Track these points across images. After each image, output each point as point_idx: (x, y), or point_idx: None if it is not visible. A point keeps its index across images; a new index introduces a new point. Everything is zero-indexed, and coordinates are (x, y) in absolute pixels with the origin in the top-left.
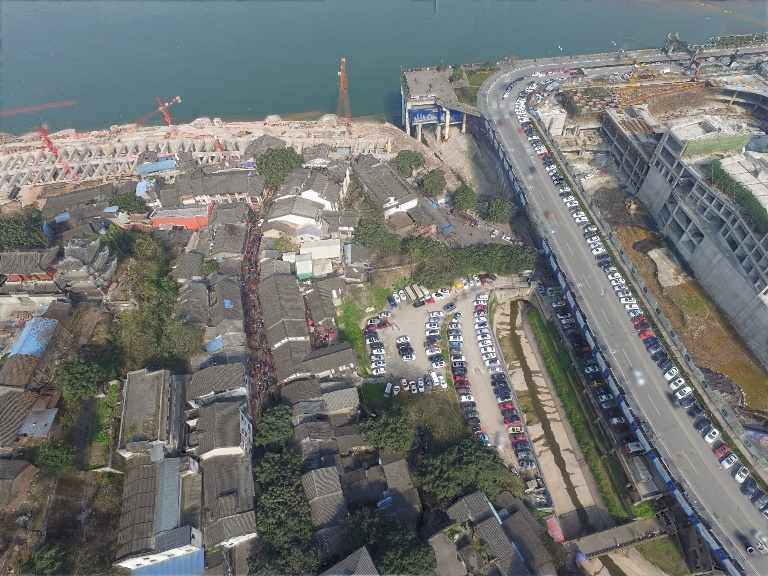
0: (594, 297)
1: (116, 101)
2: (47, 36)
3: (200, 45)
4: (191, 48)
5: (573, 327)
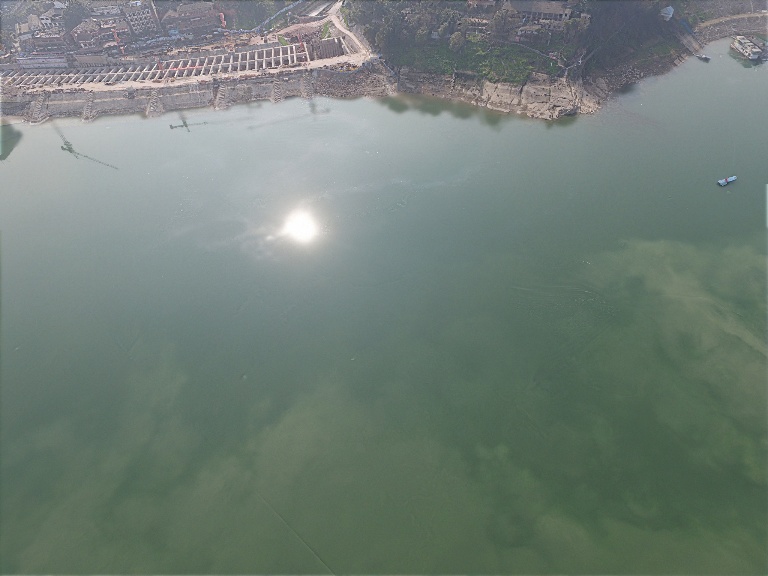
0: None
1: (247, 133)
2: (426, 243)
3: (150, 220)
4: (165, 213)
5: None
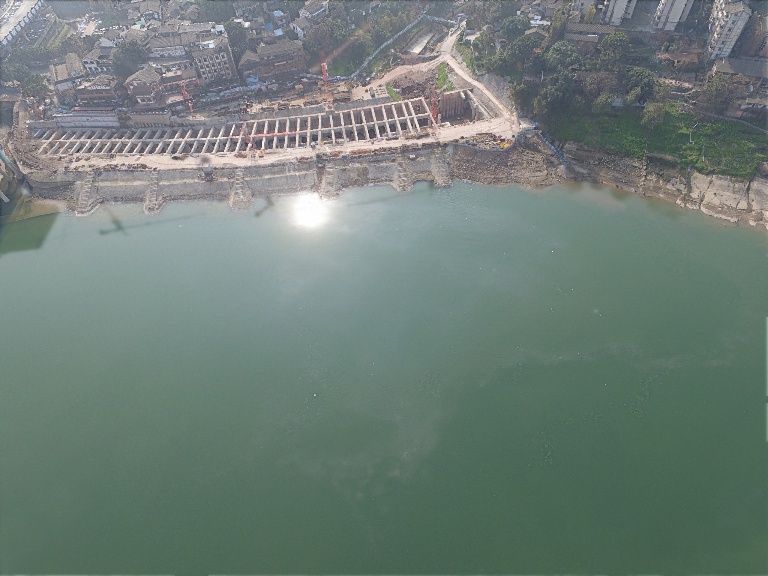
0: (6, 33)
1: (375, 244)
2: (716, 490)
3: (271, 412)
4: (289, 399)
5: (27, 47)
